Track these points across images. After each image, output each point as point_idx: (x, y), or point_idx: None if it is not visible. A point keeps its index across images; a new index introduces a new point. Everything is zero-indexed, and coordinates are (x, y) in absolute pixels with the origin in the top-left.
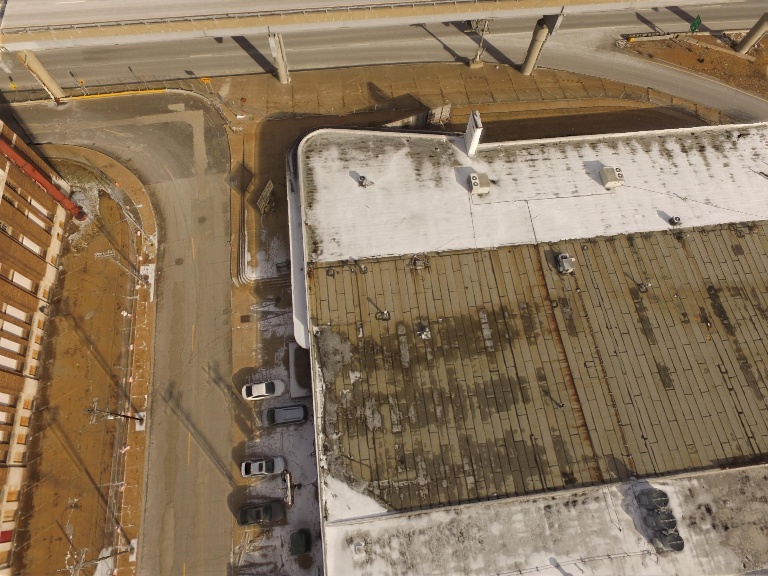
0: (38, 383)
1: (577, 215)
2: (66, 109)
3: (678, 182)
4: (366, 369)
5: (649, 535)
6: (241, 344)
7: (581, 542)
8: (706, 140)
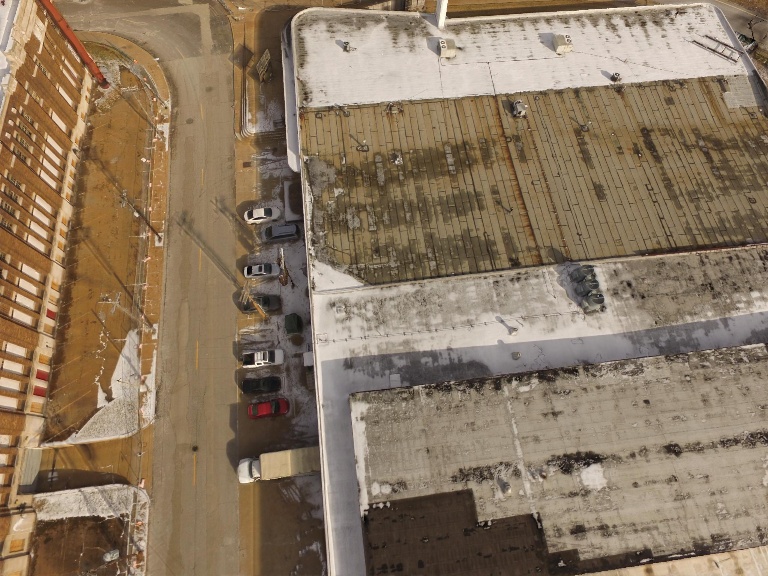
0: (73, 208)
1: (531, 73)
2: (89, 3)
3: (621, 49)
4: (348, 186)
5: (578, 301)
6: (243, 183)
7: (522, 306)
8: (648, 17)
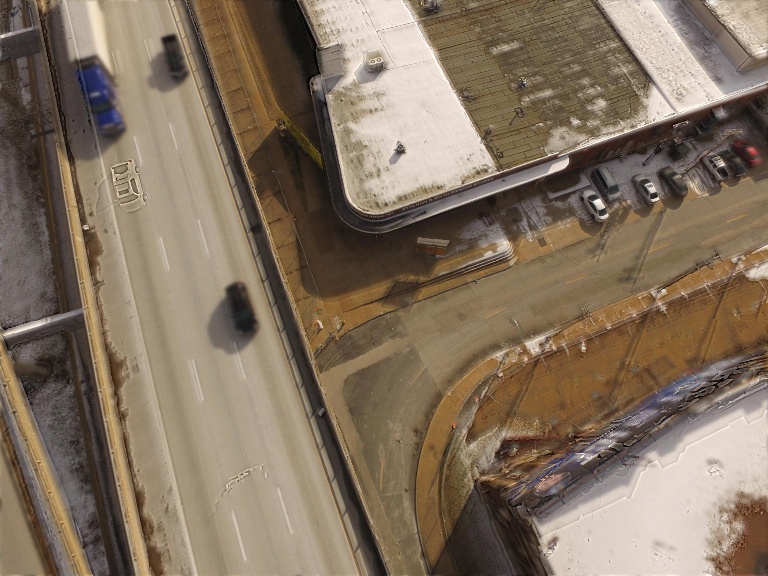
0: None
1: None
2: None
3: None
4: (565, 115)
5: None
6: (565, 238)
7: None
8: None
